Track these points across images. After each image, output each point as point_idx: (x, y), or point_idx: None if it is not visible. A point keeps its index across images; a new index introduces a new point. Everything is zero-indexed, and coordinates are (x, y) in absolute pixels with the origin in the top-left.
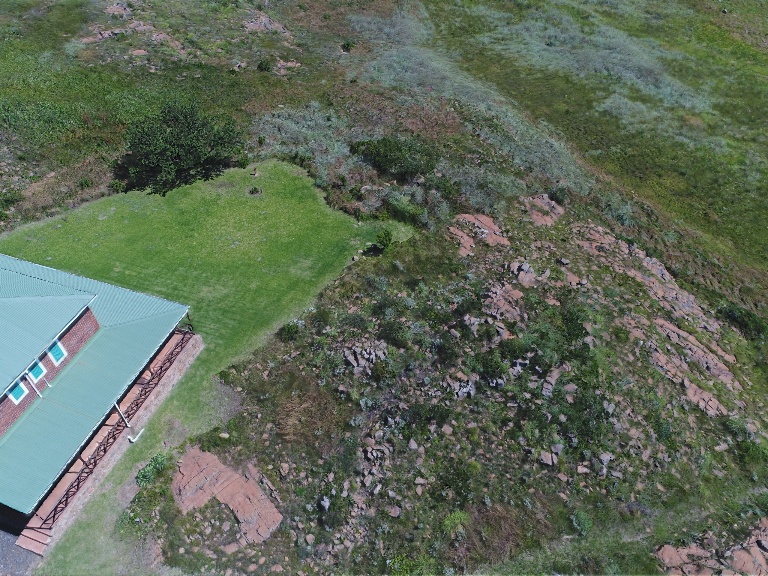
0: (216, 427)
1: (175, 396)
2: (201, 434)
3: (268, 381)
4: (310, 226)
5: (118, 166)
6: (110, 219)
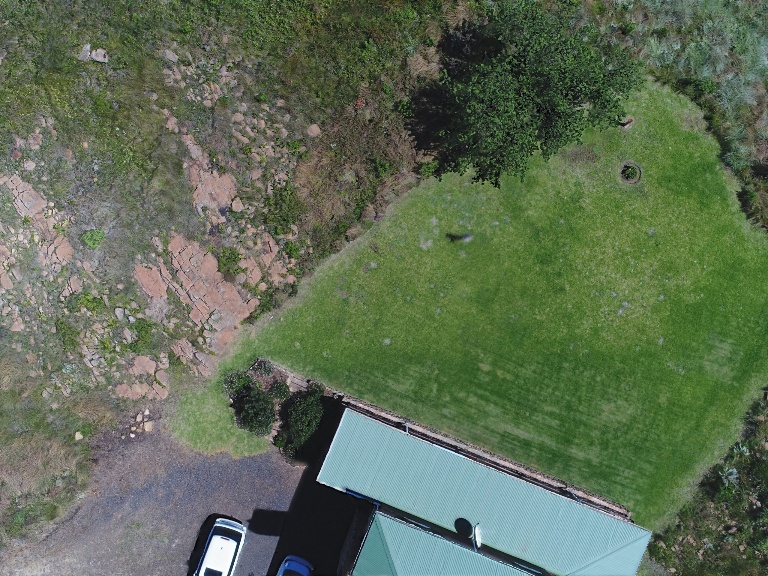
0: None
1: None
2: None
3: (708, 569)
4: (722, 267)
5: (414, 113)
6: (438, 248)
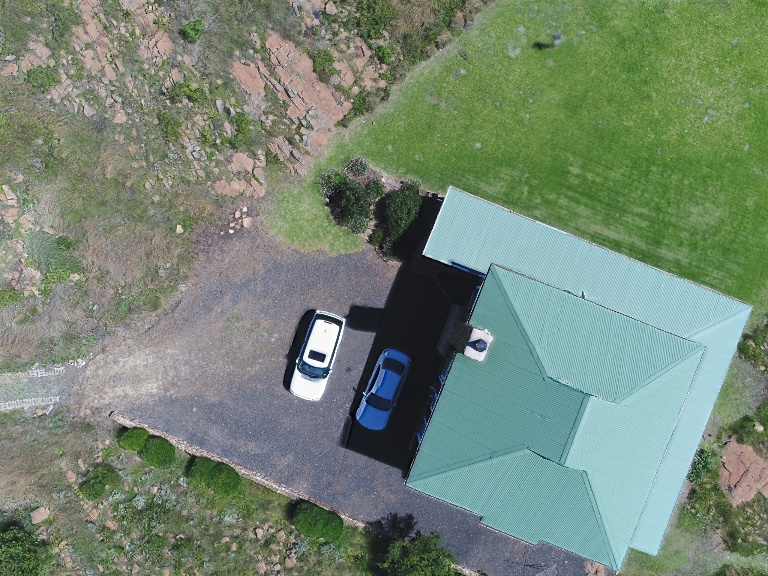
0: (750, 419)
1: None
2: (733, 423)
3: None
4: None
5: None
6: (526, 56)
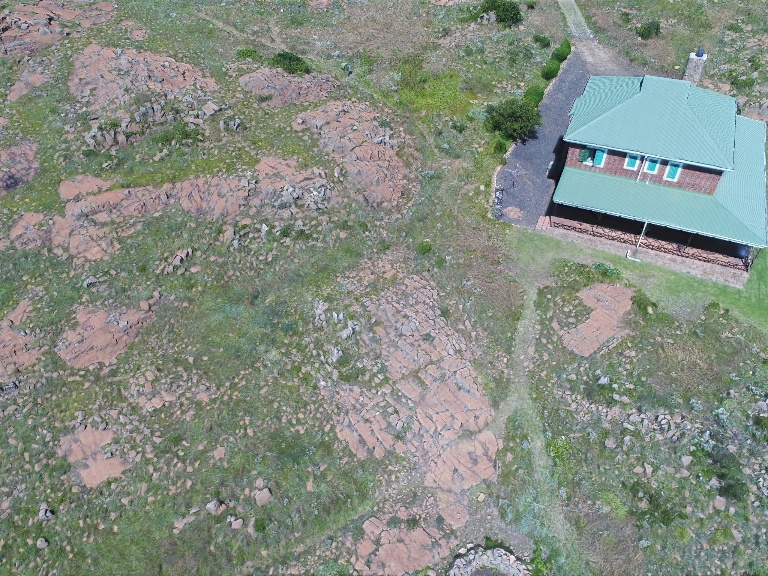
0: None
1: (679, 276)
2: (647, 296)
3: None
4: None
5: None
6: None
